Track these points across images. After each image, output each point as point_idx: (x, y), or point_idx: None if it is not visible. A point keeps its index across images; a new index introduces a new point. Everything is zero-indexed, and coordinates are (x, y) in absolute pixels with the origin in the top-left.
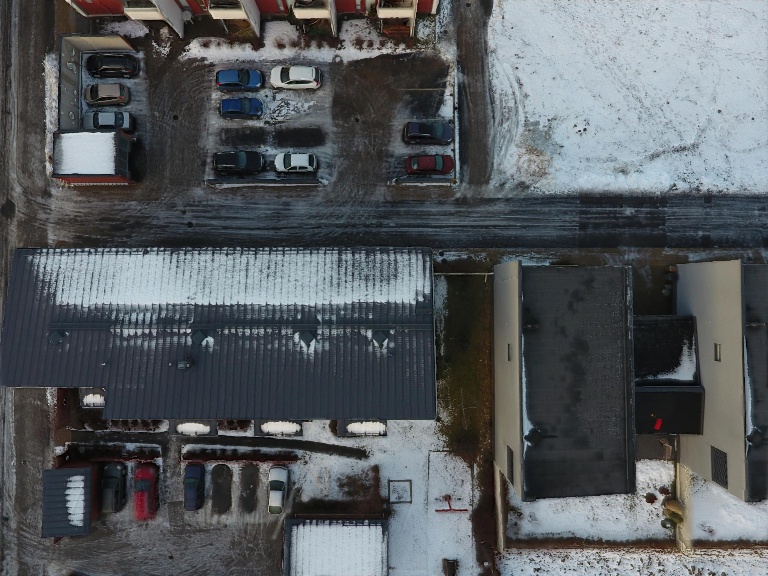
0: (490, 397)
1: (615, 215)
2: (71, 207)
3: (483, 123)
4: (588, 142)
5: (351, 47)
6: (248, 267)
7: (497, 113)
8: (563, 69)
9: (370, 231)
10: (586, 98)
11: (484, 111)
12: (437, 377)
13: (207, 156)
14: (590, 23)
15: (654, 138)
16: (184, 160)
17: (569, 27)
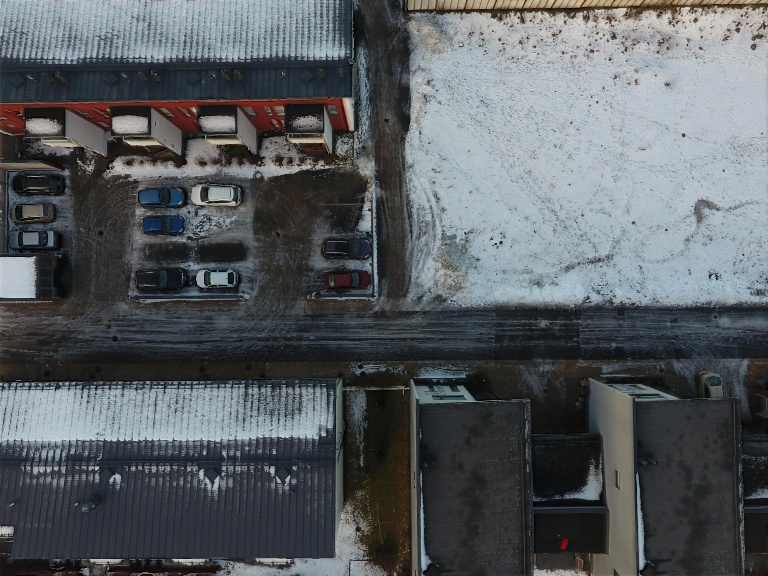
0: (409, 507)
1: (530, 327)
2: None
3: (401, 237)
4: (504, 254)
5: (271, 164)
6: (157, 402)
7: (414, 227)
8: (479, 183)
9: (291, 344)
10: (502, 211)
11: (402, 225)
12: (357, 488)
13: (131, 271)
14: (506, 137)
15: (569, 250)
16: (109, 275)
17: (485, 141)
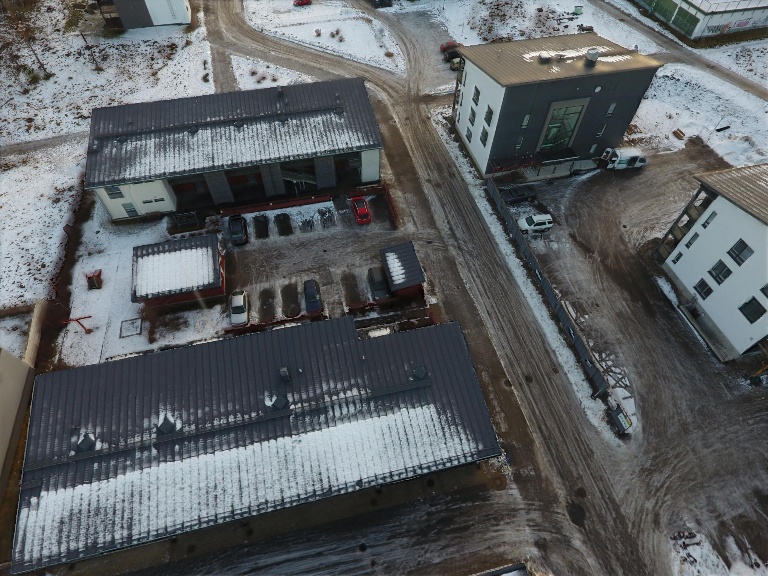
0: (24, 426)
1: None
2: (507, 535)
3: None
4: None
5: None
6: (240, 492)
7: None
8: None
9: None
10: None
11: None
12: None
13: None
14: None
15: None
16: None
17: None
